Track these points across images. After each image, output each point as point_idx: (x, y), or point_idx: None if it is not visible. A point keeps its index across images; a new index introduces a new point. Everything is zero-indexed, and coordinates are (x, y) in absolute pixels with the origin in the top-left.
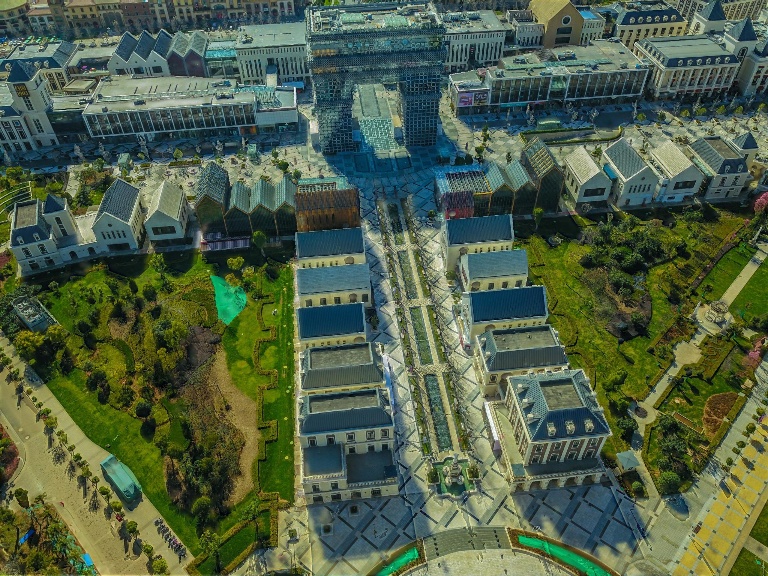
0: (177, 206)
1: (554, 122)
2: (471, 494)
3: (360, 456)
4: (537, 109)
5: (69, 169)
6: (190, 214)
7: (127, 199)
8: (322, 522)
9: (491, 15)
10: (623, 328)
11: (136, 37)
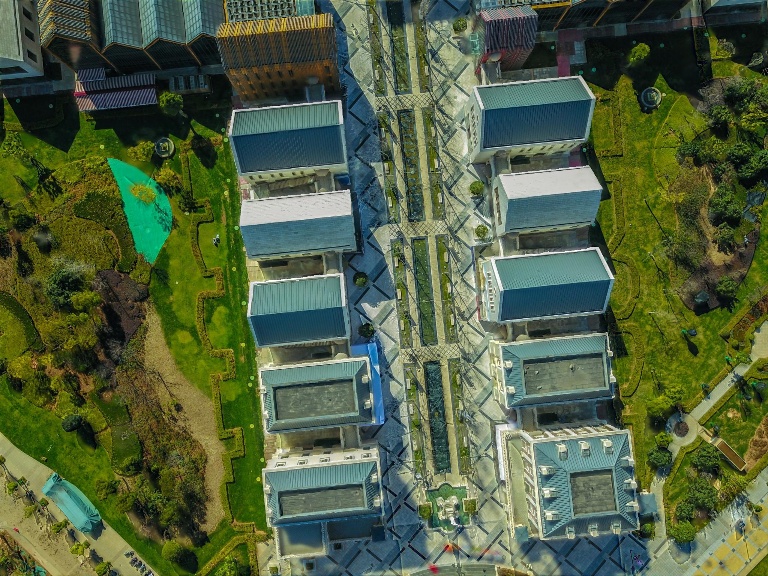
0: (11, 22)
1: None
2: (465, 528)
3: None
4: None
5: None
6: None
7: None
8: (304, 557)
9: None
10: (702, 302)
11: None
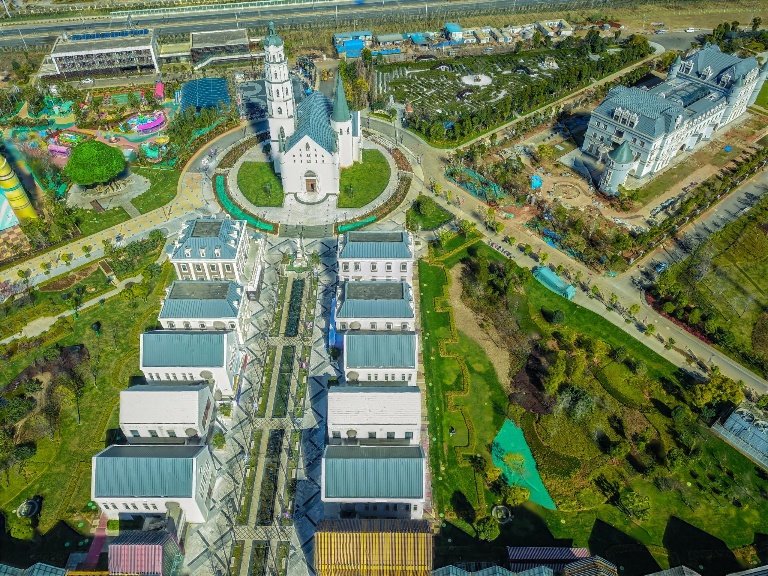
0: None
1: None
2: None
3: None
4: None
5: None
6: None
7: None
8: None
9: None
10: (76, 346)
11: None
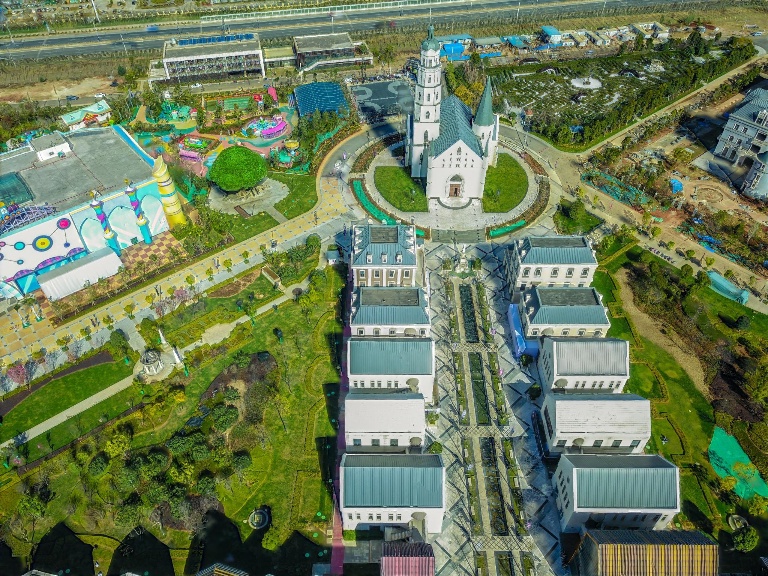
0: None
1: None
2: None
3: None
4: None
5: None
6: None
7: None
8: None
9: None
10: (265, 353)
11: None
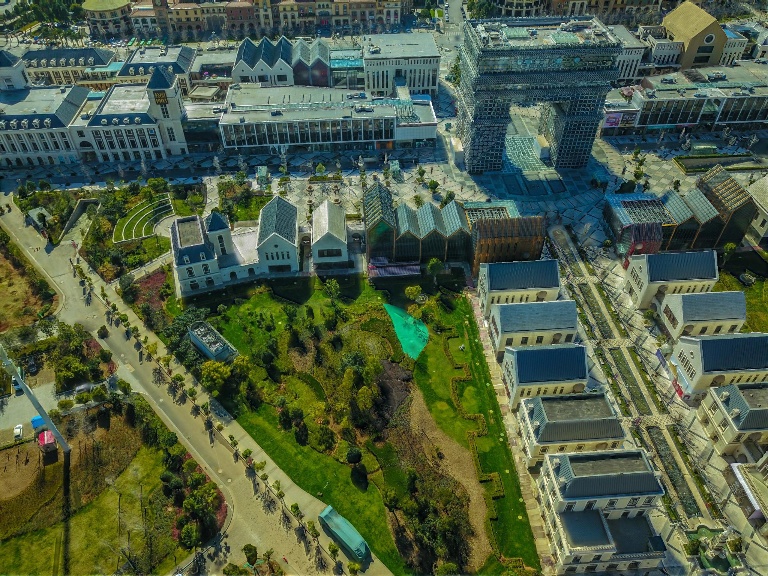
0: (343, 227)
1: (710, 147)
2: (738, 570)
3: (612, 522)
4: (684, 132)
5: (205, 181)
6: (348, 235)
7: (289, 218)
8: None
9: (624, 31)
10: None
11: (256, 43)
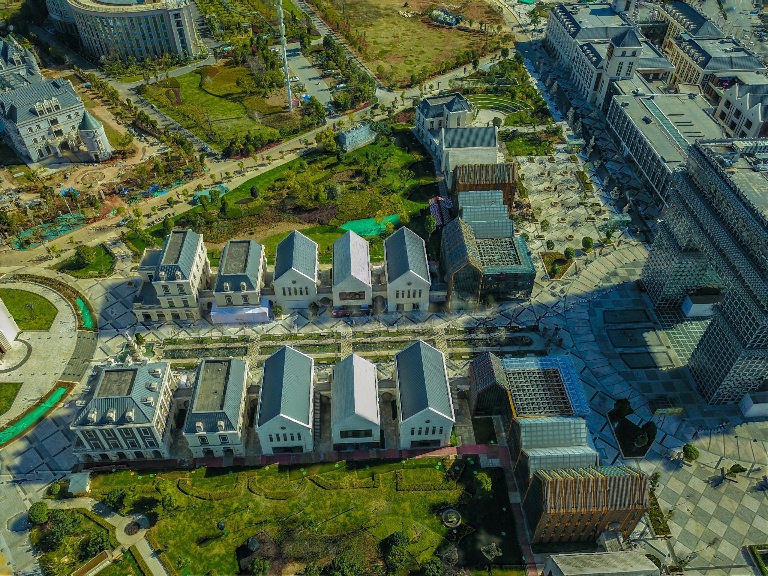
0: None
1: None
2: None
3: None
4: None
5: (560, 122)
6: None
7: (475, 140)
8: (137, 282)
9: None
10: (248, 543)
11: None
